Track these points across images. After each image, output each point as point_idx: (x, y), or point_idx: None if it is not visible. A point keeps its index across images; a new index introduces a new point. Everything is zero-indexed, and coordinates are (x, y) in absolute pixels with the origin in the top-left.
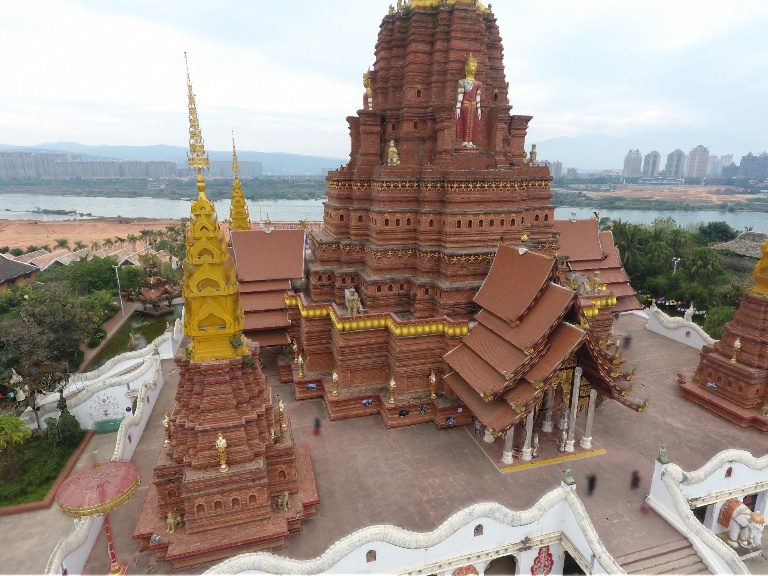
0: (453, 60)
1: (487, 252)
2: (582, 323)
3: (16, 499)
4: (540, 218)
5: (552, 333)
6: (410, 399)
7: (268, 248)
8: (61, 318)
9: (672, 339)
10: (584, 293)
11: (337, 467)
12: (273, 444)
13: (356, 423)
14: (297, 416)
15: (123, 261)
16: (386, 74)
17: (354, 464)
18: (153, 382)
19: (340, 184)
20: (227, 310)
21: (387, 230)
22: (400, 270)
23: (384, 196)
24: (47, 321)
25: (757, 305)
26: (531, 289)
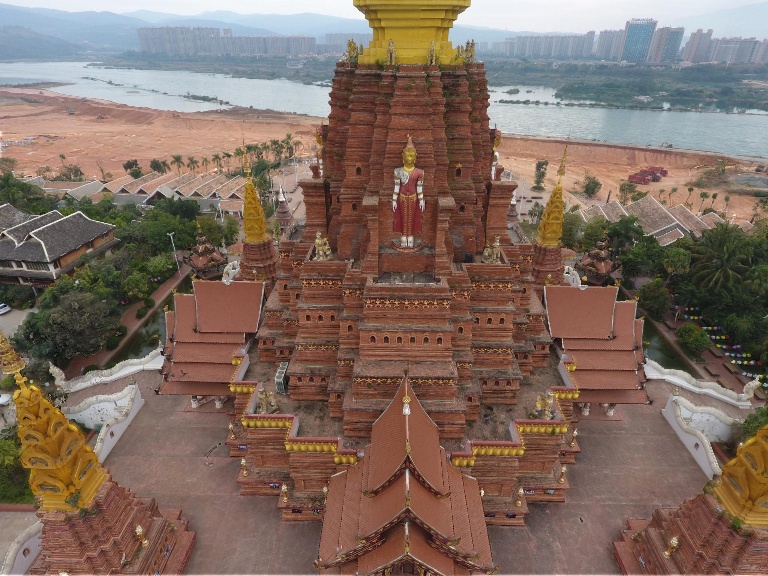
0: (391, 142)
1: (397, 376)
2: (404, 543)
3: (16, 498)
4: (494, 321)
5: (387, 531)
6: (305, 499)
7: (227, 299)
8: (78, 328)
9: (681, 441)
10: (534, 410)
11: (212, 561)
12: (119, 570)
13: (260, 504)
14: (219, 479)
15: (212, 193)
16: (335, 135)
17: (227, 562)
18: (125, 412)
19: (283, 255)
20: (62, 476)
21: (309, 325)
22: (325, 361)
23: (305, 293)
24: (69, 328)
25: (709, 512)
26: (391, 466)
